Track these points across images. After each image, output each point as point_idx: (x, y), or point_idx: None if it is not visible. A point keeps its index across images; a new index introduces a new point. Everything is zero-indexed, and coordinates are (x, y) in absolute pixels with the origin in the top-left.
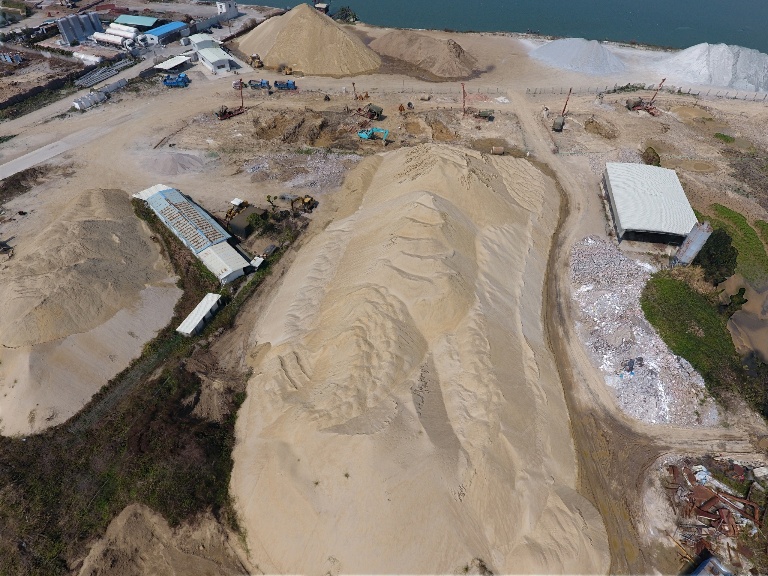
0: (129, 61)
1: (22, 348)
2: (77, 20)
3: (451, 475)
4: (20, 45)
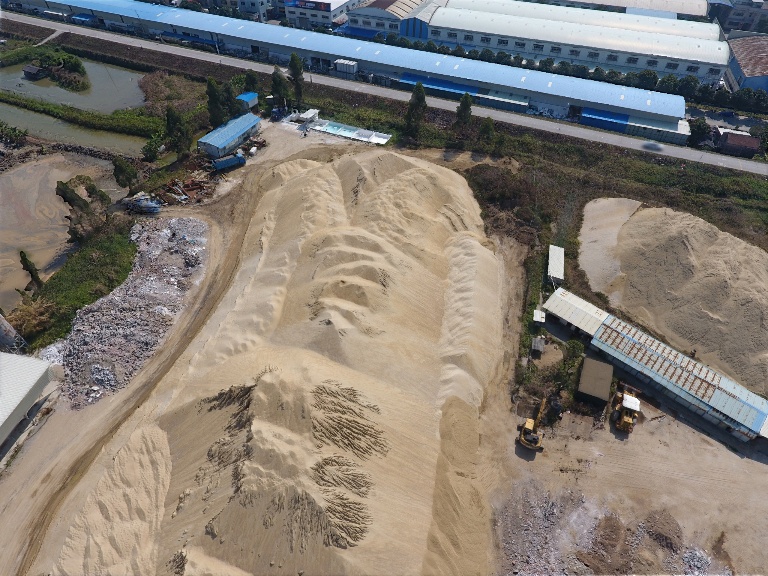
0: None
1: None
2: None
3: None
4: None
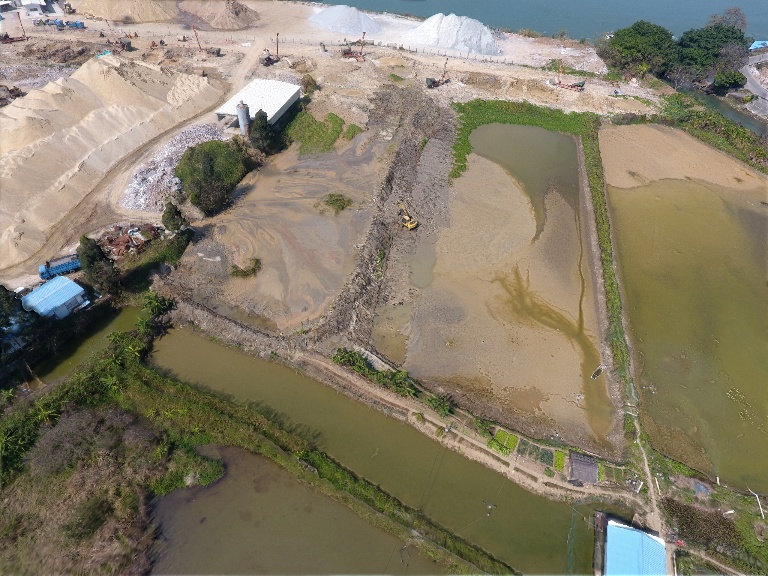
0: None
1: None
2: None
3: None
4: None
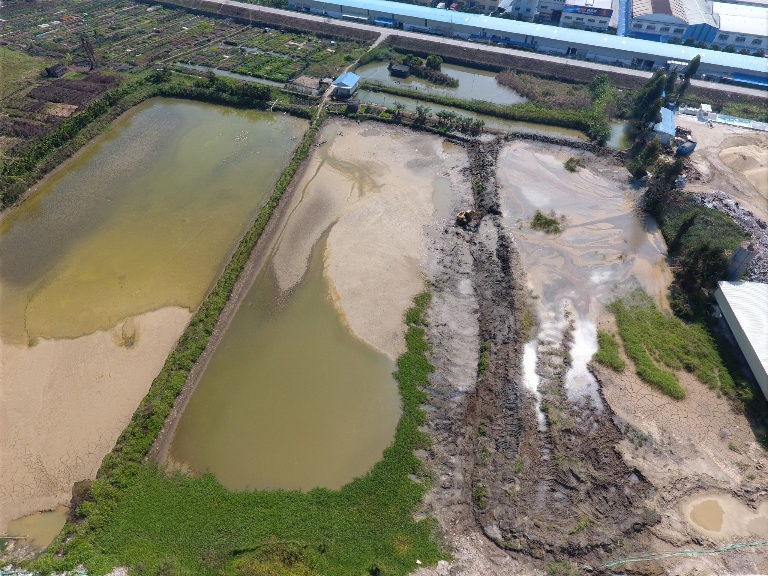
0: None
1: None
2: None
3: None
4: None
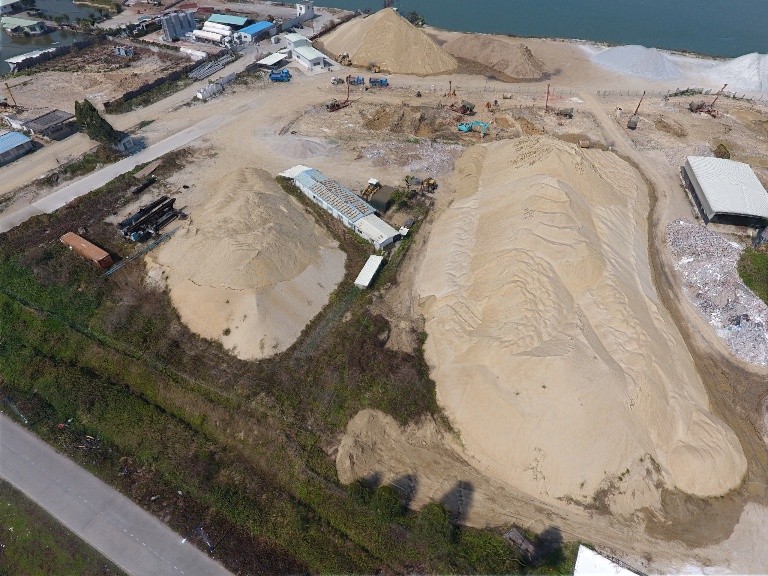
0: (231, 57)
1: (247, 290)
2: (177, 18)
3: (624, 390)
4: (129, 40)
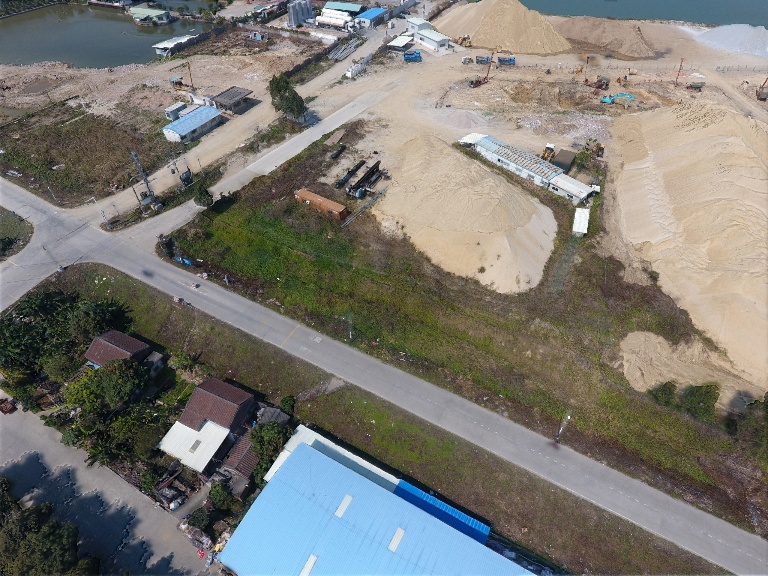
0: (358, 40)
1: (496, 233)
2: (300, 5)
3: None
4: (259, 26)
